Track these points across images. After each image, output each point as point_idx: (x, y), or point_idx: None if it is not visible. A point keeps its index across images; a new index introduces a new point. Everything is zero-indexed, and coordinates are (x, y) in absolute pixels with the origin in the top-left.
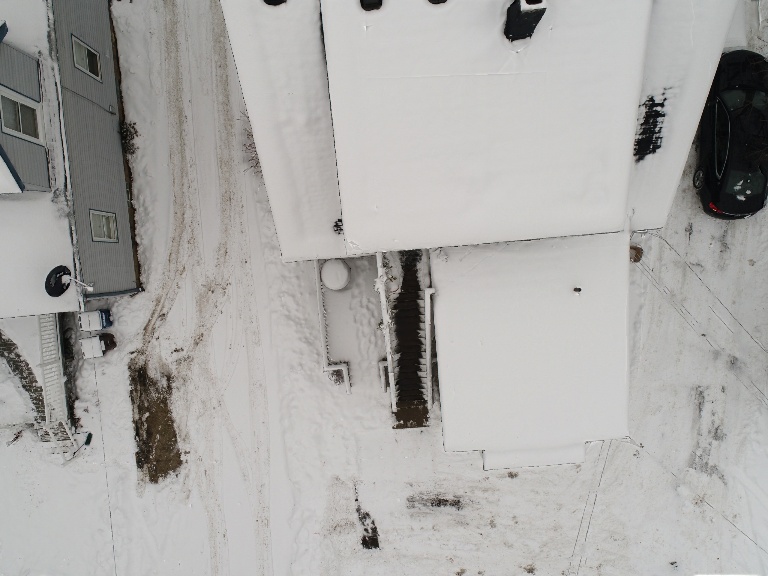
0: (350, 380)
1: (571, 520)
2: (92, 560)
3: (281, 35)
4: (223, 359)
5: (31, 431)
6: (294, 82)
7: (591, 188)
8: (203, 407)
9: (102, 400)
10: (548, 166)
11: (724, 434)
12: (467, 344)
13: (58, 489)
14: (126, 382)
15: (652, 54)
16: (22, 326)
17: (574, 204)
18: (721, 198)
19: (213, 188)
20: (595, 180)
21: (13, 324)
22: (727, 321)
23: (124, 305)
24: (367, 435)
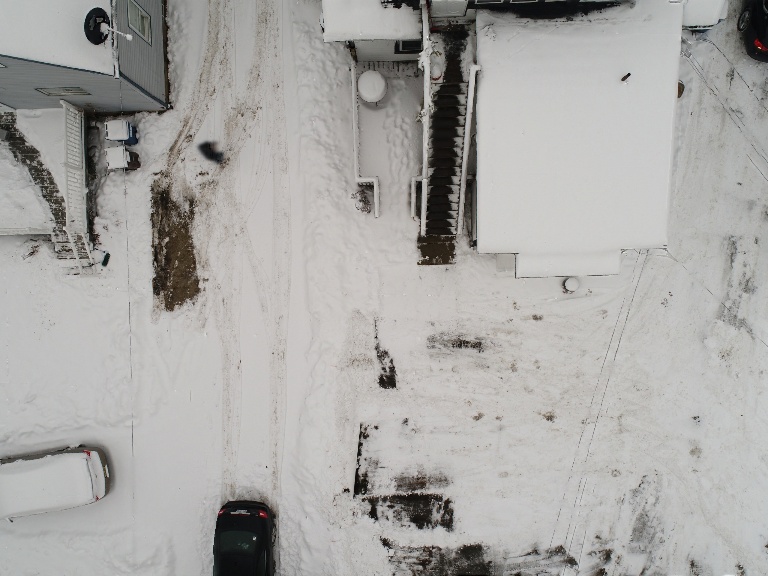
0: (379, 204)
1: (594, 367)
2: (101, 387)
3: None
4: (249, 184)
5: (48, 246)
6: None
7: None
8: (225, 233)
9: (122, 220)
10: None
11: (755, 287)
12: (509, 133)
13: (71, 312)
14: (148, 204)
15: None
16: (47, 131)
17: None
18: (767, 33)
19: (249, 8)
20: None
21: (38, 129)
22: (764, 171)
23: (151, 122)
24: (391, 270)
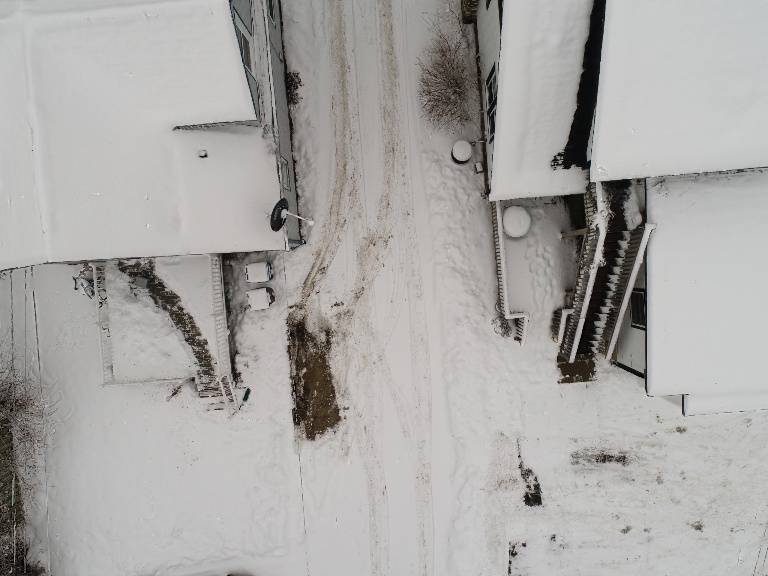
0: None
1: (741, 476)
2: (247, 519)
3: None
4: (384, 313)
5: (190, 386)
6: None
7: None
8: (363, 362)
9: (260, 355)
10: None
11: None
12: (681, 283)
13: (213, 446)
14: (284, 337)
15: None
16: (187, 278)
17: None
18: None
19: (376, 139)
20: None
21: (178, 276)
22: None
23: (285, 258)
24: (531, 390)
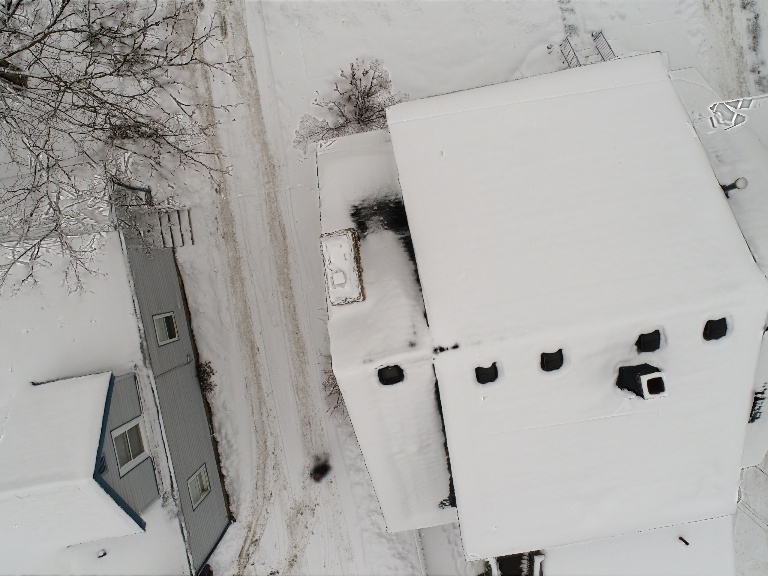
0: None
1: None
2: None
3: (397, 402)
4: None
5: None
6: (407, 427)
7: (703, 488)
8: None
9: None
10: (662, 478)
11: None
12: None
13: None
14: None
15: (759, 377)
16: None
17: (688, 502)
18: None
19: (292, 415)
20: (707, 482)
21: None
22: None
23: None
24: None
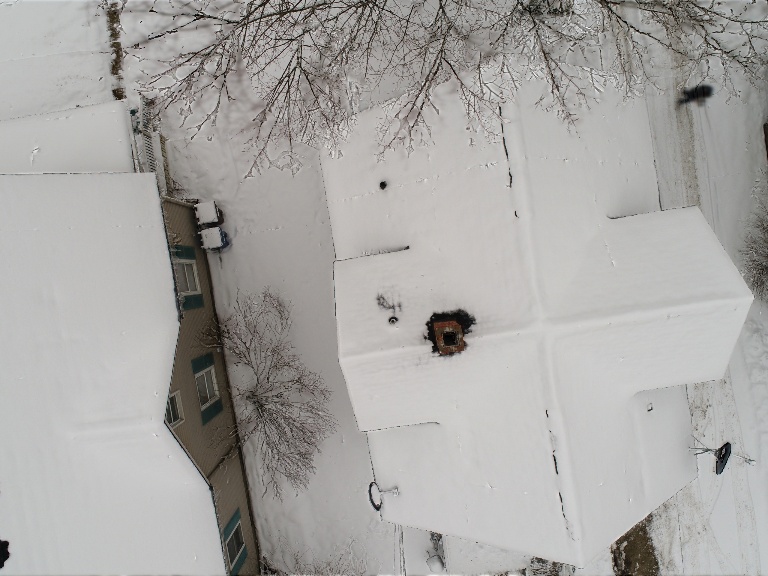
0: None
1: None
2: None
3: None
4: (707, 483)
5: (517, 571)
6: None
7: None
8: (688, 533)
9: None
10: None
11: None
12: None
13: None
14: None
15: None
16: None
17: None
18: None
19: None
20: None
21: None
22: None
23: None
24: None
